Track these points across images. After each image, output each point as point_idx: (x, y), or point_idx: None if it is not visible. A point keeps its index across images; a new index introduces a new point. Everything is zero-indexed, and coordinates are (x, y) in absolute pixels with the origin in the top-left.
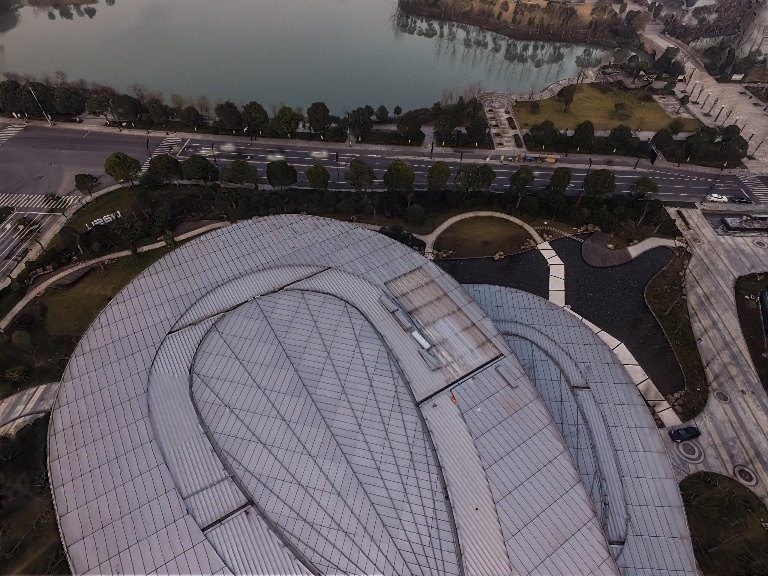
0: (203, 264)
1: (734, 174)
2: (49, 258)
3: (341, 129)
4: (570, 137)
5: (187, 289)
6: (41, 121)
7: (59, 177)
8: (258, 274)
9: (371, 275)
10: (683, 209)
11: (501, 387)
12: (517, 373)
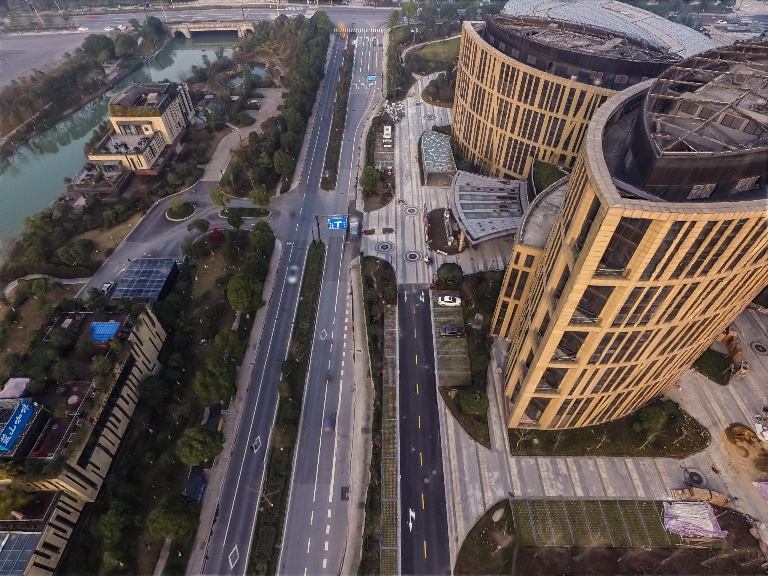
0: (528, 1)
1: (729, 15)
2: (405, 39)
3: (505, 2)
4: (636, 1)
5: (529, 5)
6: (325, 5)
7: (364, 23)
8: (551, 3)
9: (594, 3)
10: (704, 26)
11: (658, 20)
12: (662, 18)
